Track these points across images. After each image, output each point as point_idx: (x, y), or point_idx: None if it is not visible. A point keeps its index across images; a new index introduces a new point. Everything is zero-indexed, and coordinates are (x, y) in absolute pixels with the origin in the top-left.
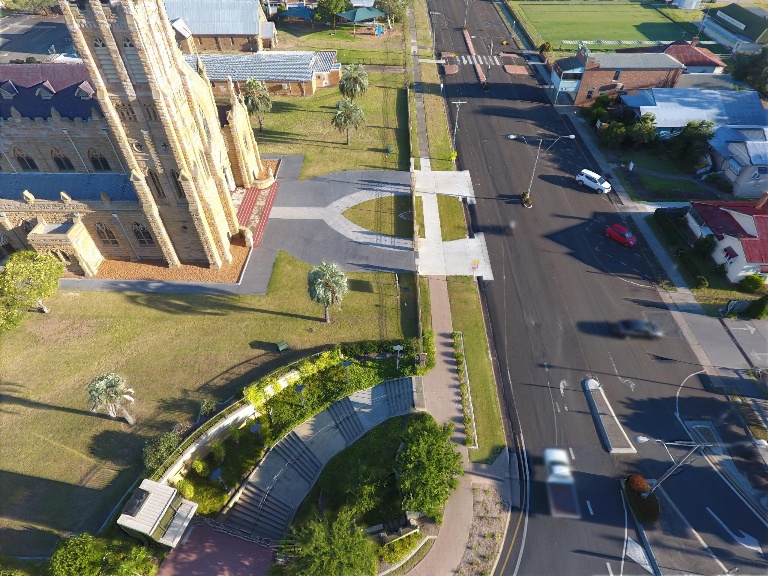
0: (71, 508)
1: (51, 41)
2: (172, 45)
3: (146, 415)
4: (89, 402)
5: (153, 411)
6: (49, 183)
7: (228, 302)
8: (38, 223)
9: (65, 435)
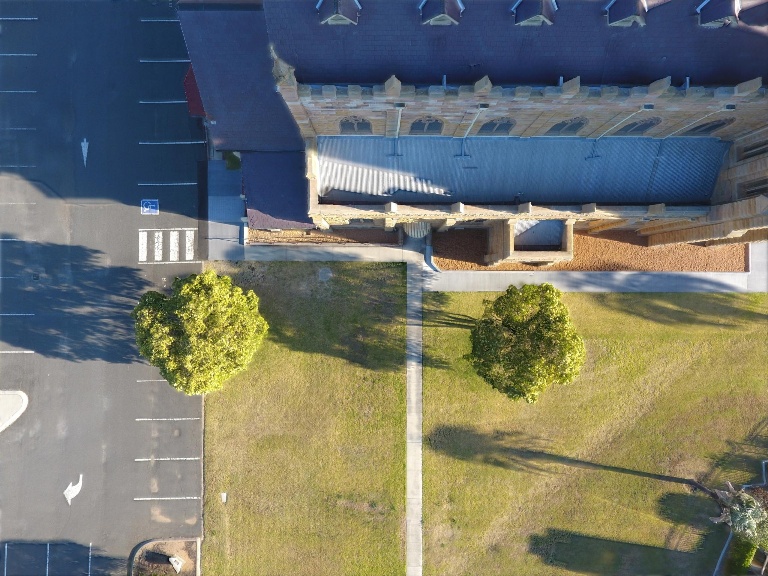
0: (674, 570)
1: None
2: None
3: (706, 475)
4: (637, 460)
5: (712, 470)
6: (523, 156)
7: (743, 306)
8: (510, 226)
9: (632, 500)
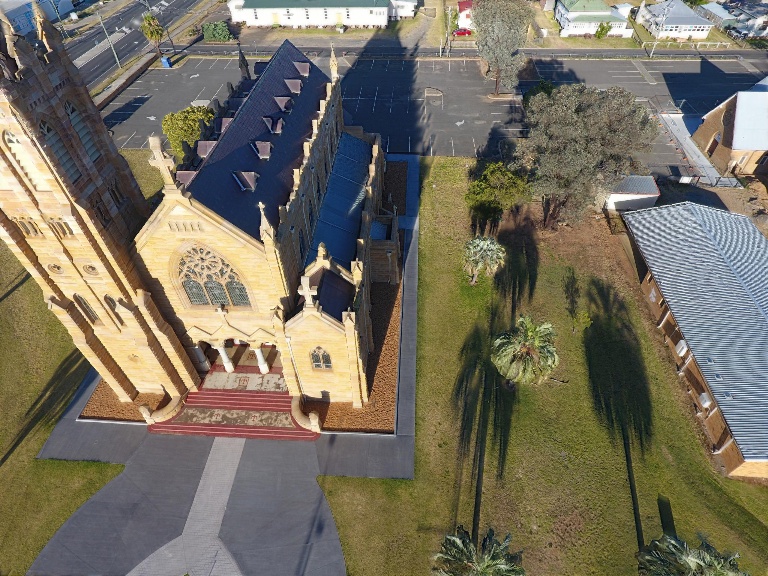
0: None
1: (721, 95)
2: (40, 170)
3: None
4: None
5: None
6: None
7: (50, 412)
8: None
9: None
